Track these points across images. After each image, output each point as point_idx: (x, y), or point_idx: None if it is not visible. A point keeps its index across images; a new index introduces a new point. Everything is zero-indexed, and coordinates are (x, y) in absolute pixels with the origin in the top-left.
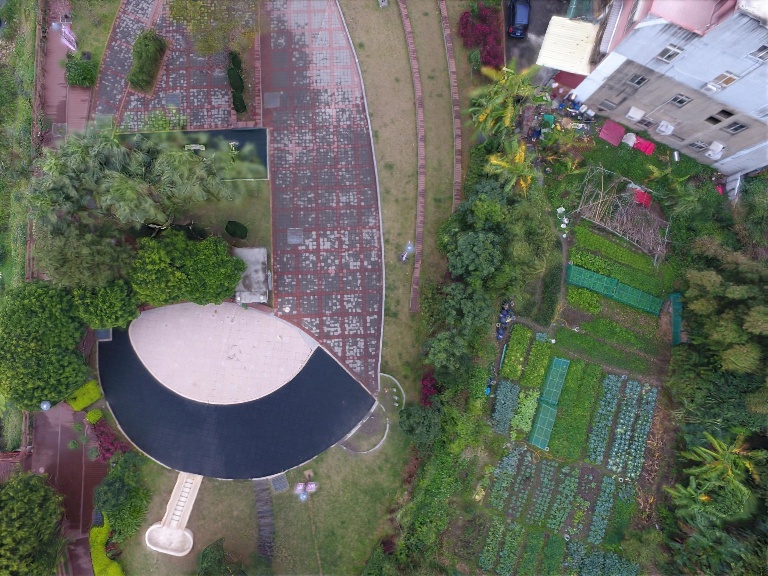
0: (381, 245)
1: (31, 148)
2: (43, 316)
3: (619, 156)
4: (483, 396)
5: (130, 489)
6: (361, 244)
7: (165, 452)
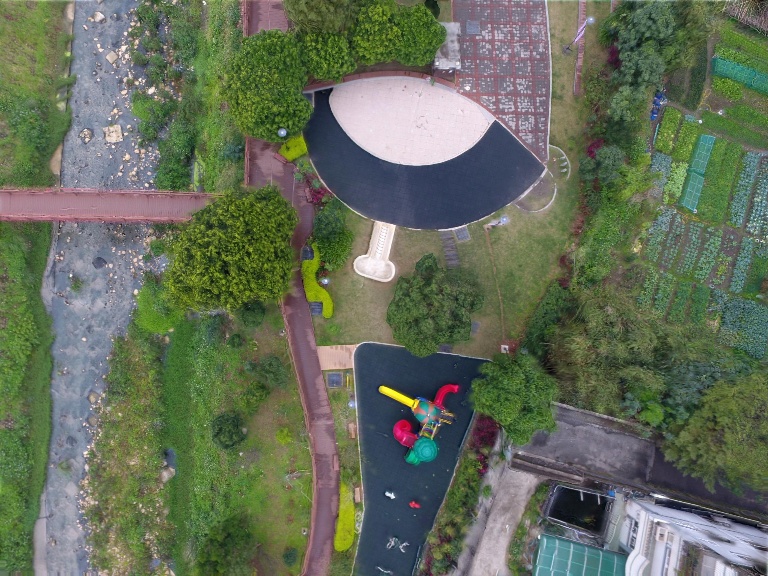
0: (548, 39)
1: None
2: (283, 54)
3: None
4: None
5: (340, 224)
6: (530, 37)
7: (362, 204)
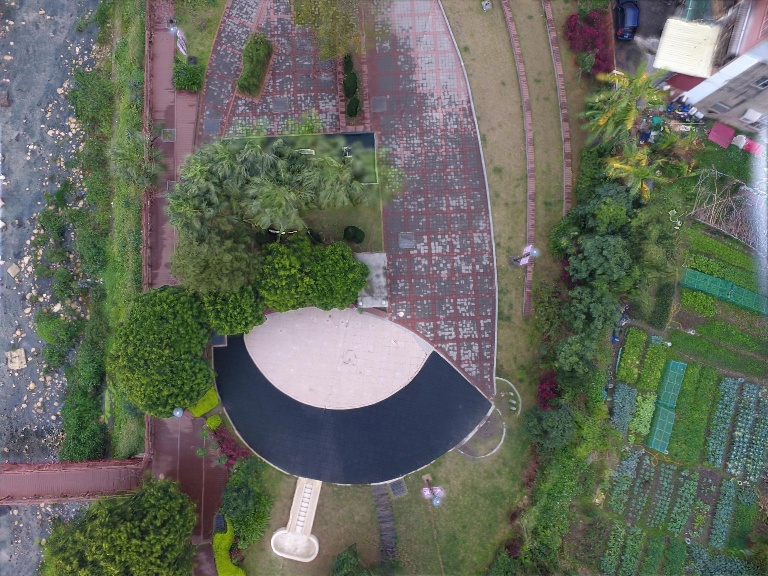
0: (492, 249)
1: (144, 154)
2: (175, 323)
3: (729, 158)
4: (602, 400)
5: (255, 495)
6: (472, 248)
7: (283, 458)
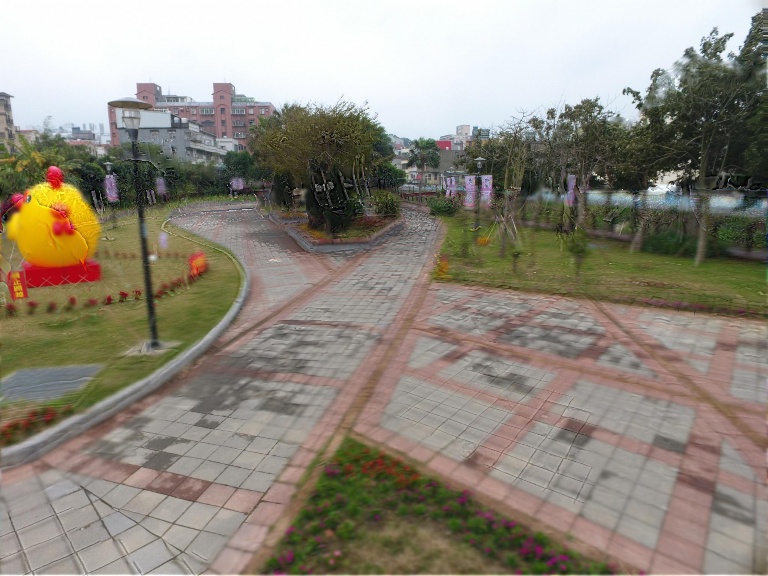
0: None
1: None
2: None
3: None
4: None
5: None
6: None
7: None
